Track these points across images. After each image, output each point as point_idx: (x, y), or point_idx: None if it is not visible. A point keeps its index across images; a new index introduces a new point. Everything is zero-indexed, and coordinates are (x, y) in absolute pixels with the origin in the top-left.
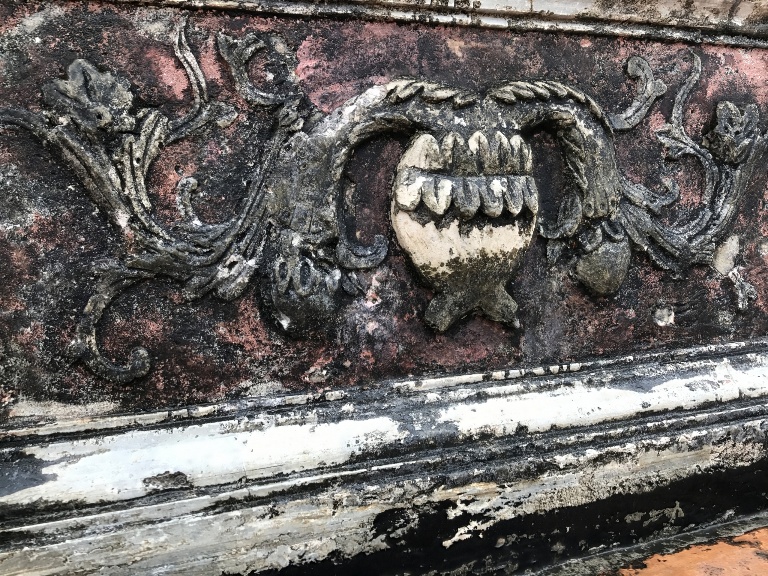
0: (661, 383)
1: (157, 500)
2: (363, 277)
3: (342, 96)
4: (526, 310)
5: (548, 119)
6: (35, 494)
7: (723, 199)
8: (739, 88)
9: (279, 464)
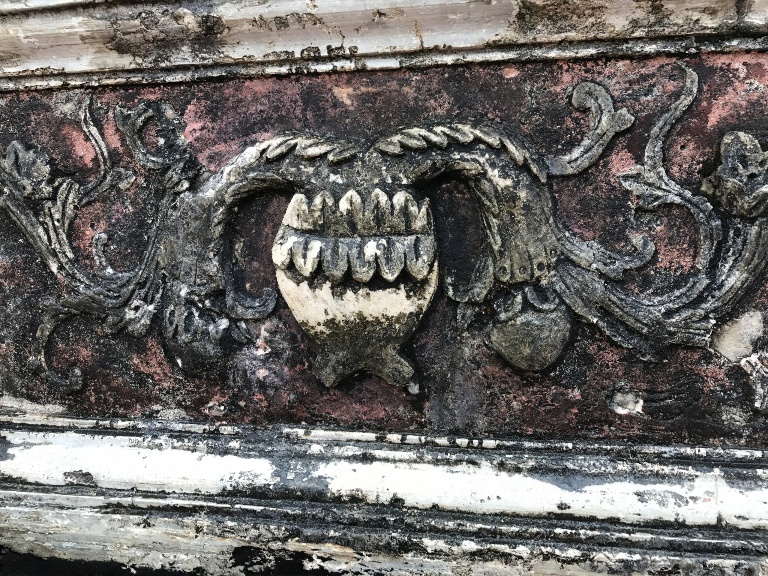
0: (601, 483)
1: (70, 491)
2: (252, 327)
3: (228, 155)
4: (431, 375)
5: (450, 169)
6: None
7: (730, 264)
8: None
9: (162, 483)
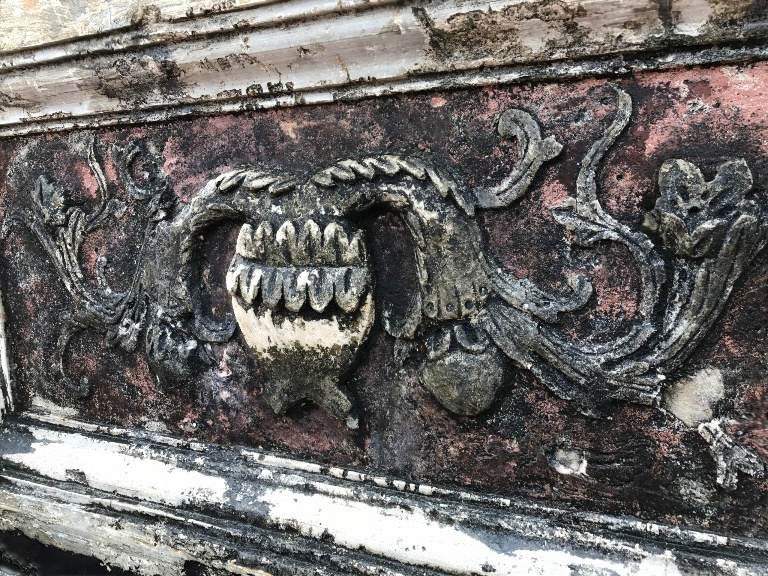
0: (535, 549)
1: (68, 487)
2: (217, 349)
3: (197, 187)
4: (371, 411)
5: (380, 201)
6: (21, 458)
7: (677, 311)
8: (718, 133)
9: (136, 490)
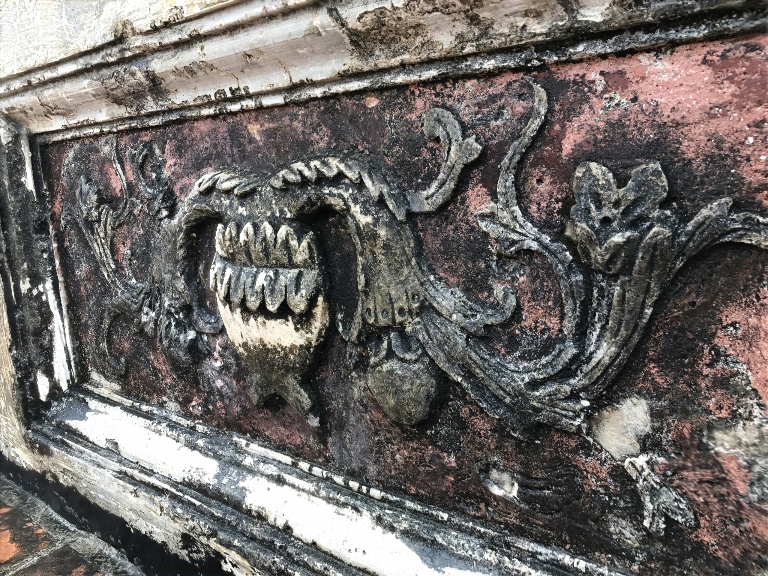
0: (463, 568)
1: (106, 454)
2: (211, 340)
3: (190, 187)
4: (331, 411)
5: (324, 204)
6: (77, 425)
7: (597, 332)
8: (635, 132)
9: (152, 463)
